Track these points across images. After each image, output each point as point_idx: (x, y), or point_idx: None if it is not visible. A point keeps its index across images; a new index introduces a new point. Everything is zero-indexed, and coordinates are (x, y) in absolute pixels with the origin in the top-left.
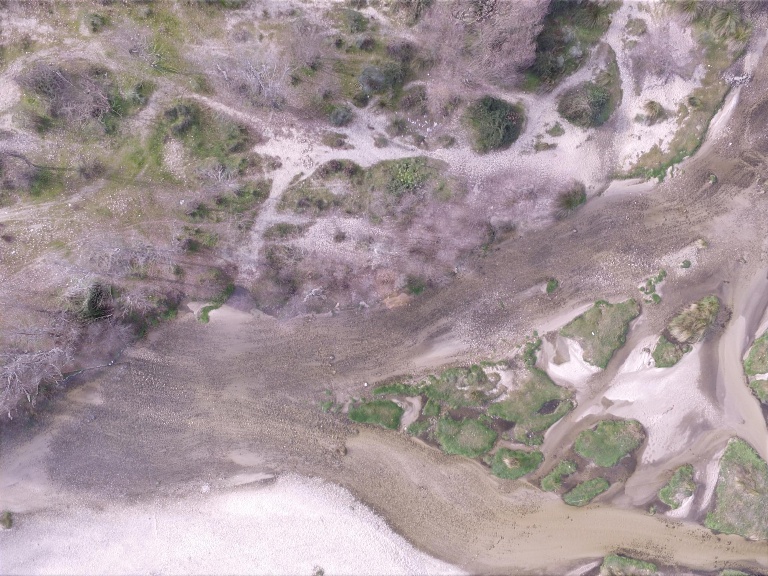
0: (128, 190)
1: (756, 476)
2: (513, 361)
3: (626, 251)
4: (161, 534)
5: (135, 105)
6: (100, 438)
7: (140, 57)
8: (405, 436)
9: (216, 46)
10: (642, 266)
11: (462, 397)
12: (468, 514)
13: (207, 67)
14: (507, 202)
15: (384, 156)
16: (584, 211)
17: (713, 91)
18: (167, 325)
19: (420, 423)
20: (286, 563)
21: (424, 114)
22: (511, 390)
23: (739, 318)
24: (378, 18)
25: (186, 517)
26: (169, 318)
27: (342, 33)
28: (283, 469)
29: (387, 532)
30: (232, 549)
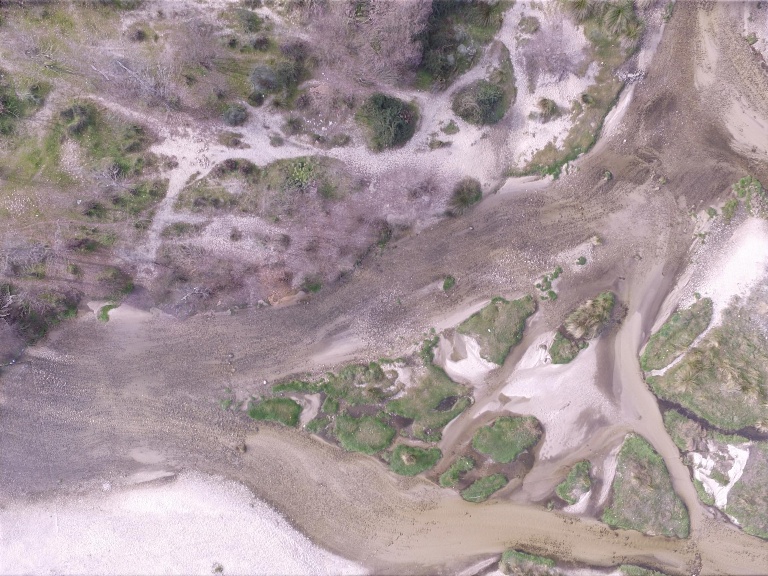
0: (26, 190)
1: (652, 471)
2: (411, 358)
3: (522, 248)
4: (62, 532)
5: (31, 106)
6: (2, 437)
7: (32, 58)
8: (304, 433)
9: (112, 47)
10: (538, 263)
11: (360, 394)
12: (367, 511)
13: (103, 68)
14: (402, 200)
15: (280, 155)
16: (480, 208)
17: (607, 88)
18: (67, 324)
19: (319, 420)
20: (185, 560)
21: (319, 113)
22: (409, 387)
23: (635, 314)
24: (273, 18)
25: (87, 515)
26: (69, 317)
27: (237, 33)
28: (183, 467)
29: (286, 529)
30: (132, 546)
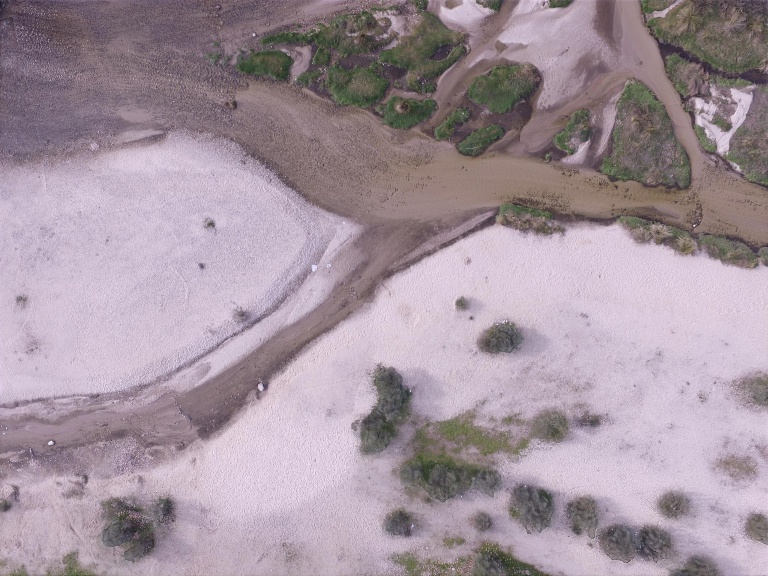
0: None
1: (653, 117)
2: (404, 7)
3: None
4: (51, 191)
5: None
6: None
7: None
8: (296, 88)
9: None
10: None
11: (352, 43)
12: (361, 166)
13: None
14: None
15: None
16: None
17: None
18: None
19: (310, 73)
20: (177, 216)
21: None
22: (402, 35)
23: None
24: None
25: (76, 175)
26: None
27: None
28: (173, 125)
29: (279, 186)
30: (122, 203)
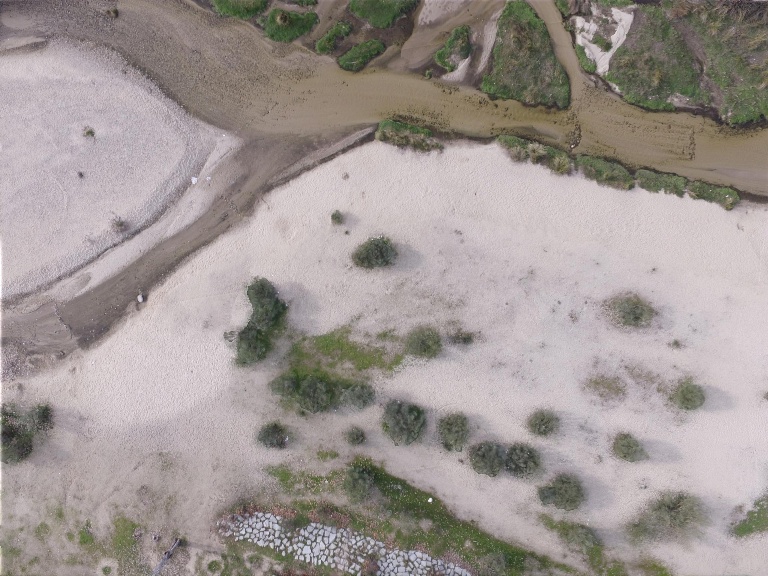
0: None
1: (533, 34)
2: None
3: None
4: None
5: None
6: None
7: None
8: None
9: None
10: None
11: None
12: (242, 79)
13: None
14: None
15: None
16: None
17: None
18: None
19: None
20: (56, 124)
21: None
22: None
23: None
24: None
25: None
26: None
27: None
28: (54, 32)
29: (160, 96)
30: (2, 109)
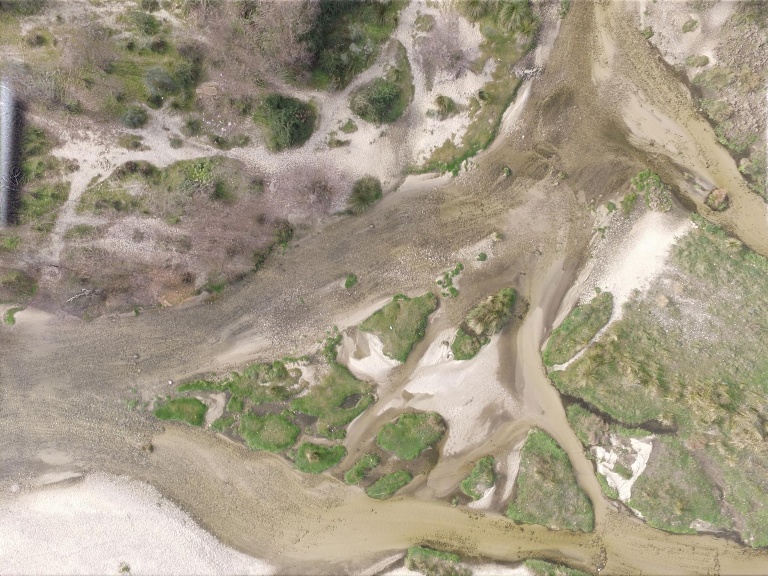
0: None
1: (555, 466)
2: (315, 356)
3: (423, 245)
4: None
5: None
6: None
7: None
8: (210, 433)
9: (12, 52)
10: (439, 260)
11: (264, 393)
12: (273, 509)
13: None
14: (302, 199)
15: (180, 156)
16: (381, 206)
17: (504, 84)
18: None
19: (224, 419)
20: (93, 560)
21: (218, 114)
22: (312, 385)
23: (536, 309)
24: (170, 20)
25: None
26: None
27: (135, 36)
28: (91, 467)
29: (194, 528)
30: (40, 547)
